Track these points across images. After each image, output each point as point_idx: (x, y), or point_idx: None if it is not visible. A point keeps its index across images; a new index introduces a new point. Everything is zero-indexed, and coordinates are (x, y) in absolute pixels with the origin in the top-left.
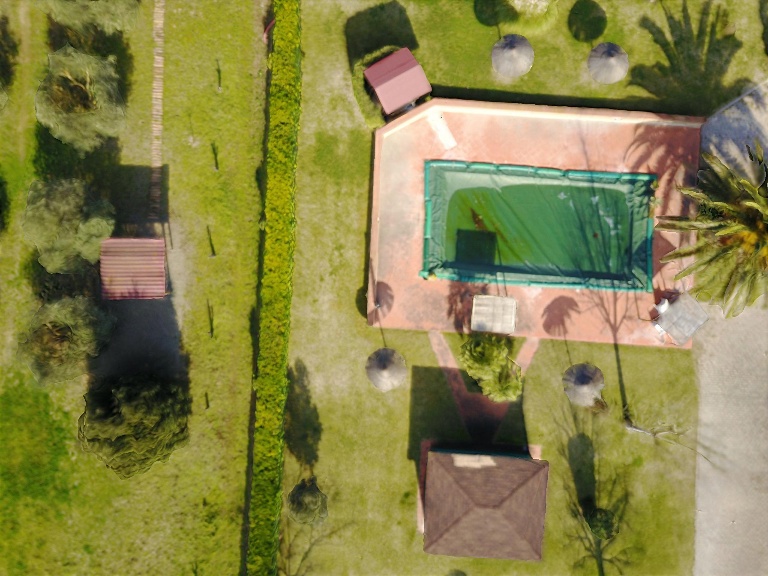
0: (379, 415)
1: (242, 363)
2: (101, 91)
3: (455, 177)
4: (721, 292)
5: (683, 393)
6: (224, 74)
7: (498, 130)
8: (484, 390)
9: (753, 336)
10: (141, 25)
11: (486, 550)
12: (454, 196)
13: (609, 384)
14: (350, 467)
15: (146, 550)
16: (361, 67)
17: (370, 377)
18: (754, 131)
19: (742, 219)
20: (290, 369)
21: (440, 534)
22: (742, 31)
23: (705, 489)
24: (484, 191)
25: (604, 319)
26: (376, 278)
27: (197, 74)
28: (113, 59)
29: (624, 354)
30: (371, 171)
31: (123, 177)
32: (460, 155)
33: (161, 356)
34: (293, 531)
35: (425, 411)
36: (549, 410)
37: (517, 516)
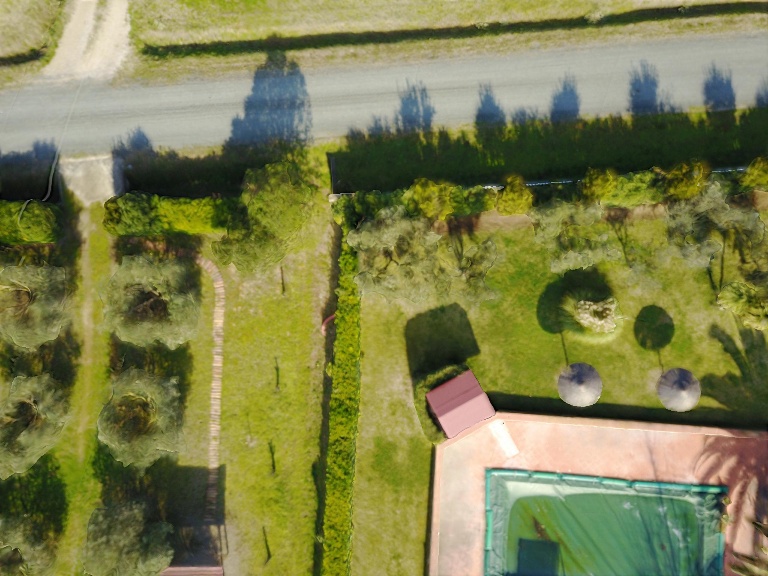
0: None
1: None
2: (163, 416)
3: (517, 486)
4: None
5: None
6: (282, 371)
7: (561, 438)
8: None
9: None
10: (201, 324)
11: None
12: (516, 504)
13: None
14: None
15: None
16: (423, 389)
17: None
18: None
19: None
20: None
21: None
22: None
23: None
24: (547, 499)
25: None
26: None
27: (255, 372)
28: (175, 380)
29: None
30: (431, 480)
31: (180, 477)
32: (522, 463)
33: None
34: None
35: None
36: None
37: None
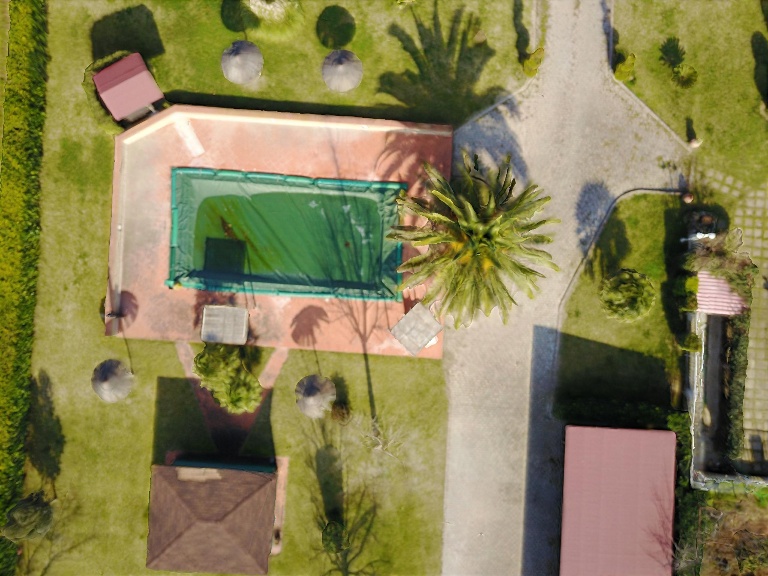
0: (123, 427)
1: None
2: None
3: (202, 185)
4: (451, 303)
5: (433, 404)
6: None
7: (247, 137)
8: (221, 402)
9: (504, 346)
10: None
11: (210, 565)
12: (203, 204)
13: (358, 395)
14: (92, 480)
15: None
16: (91, 72)
17: (95, 389)
18: (508, 140)
19: (453, 230)
20: (34, 380)
21: (162, 549)
22: (495, 39)
23: (454, 501)
24: (234, 199)
25: (354, 329)
26: (120, 287)
27: None
28: None
29: (374, 365)
30: None
31: None
32: (208, 162)
33: None
34: (32, 546)
35: (170, 423)
36: (297, 421)
37: (241, 531)
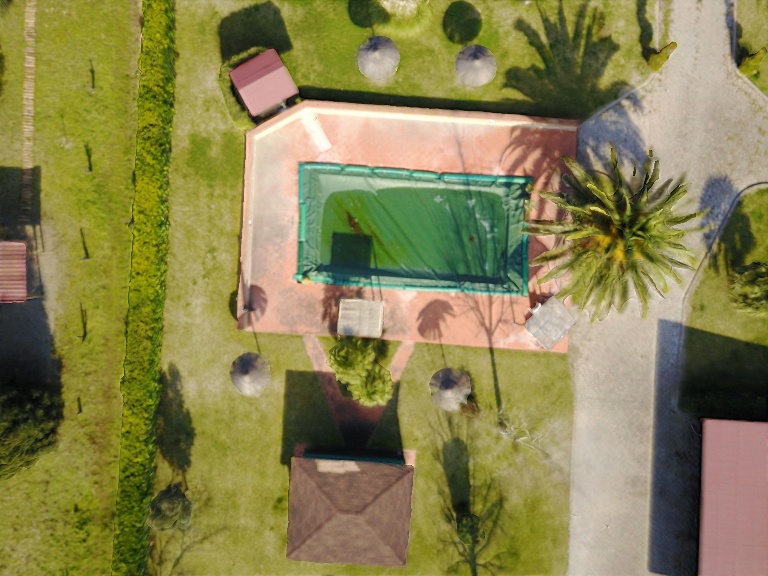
0: (252, 420)
1: (118, 367)
2: None
3: (330, 180)
4: None
5: (558, 397)
6: (98, 75)
7: (373, 132)
8: (354, 395)
9: (629, 340)
10: (12, 24)
11: (349, 556)
12: (329, 199)
13: (484, 388)
14: (223, 472)
15: (15, 557)
16: (227, 68)
17: (234, 382)
18: (631, 134)
19: (598, 223)
20: (163, 373)
21: (303, 540)
22: (619, 34)
23: (580, 493)
24: (360, 194)
25: (479, 323)
26: (249, 281)
27: (70, 74)
28: None
29: (500, 358)
30: (244, 173)
31: None
32: (335, 157)
33: (32, 360)
34: (165, 537)
35: (299, 416)
36: (424, 414)
37: (380, 522)
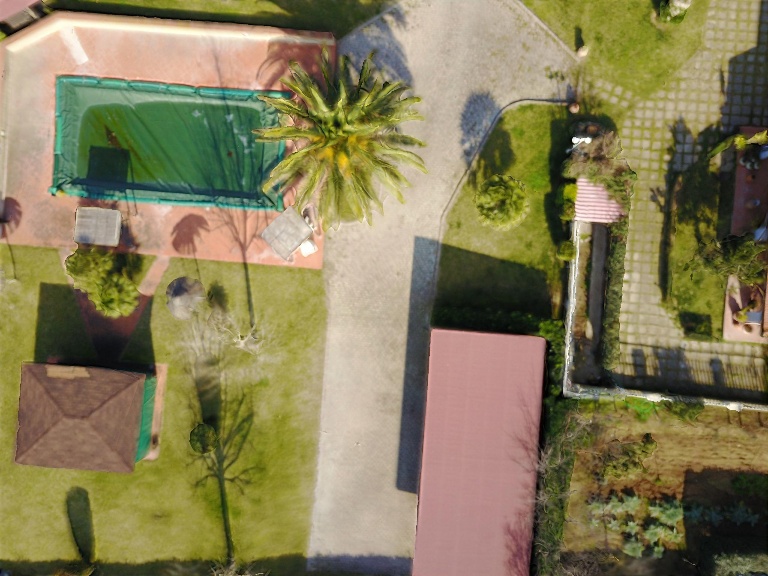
0: (6, 331)
1: None
2: None
3: (86, 93)
4: (320, 205)
5: (313, 314)
6: None
7: (130, 46)
8: (96, 305)
9: (385, 257)
10: None
11: (77, 461)
12: (87, 112)
13: (237, 303)
14: None
15: None
16: None
17: None
18: (393, 50)
19: (312, 125)
20: None
21: (31, 444)
22: None
23: (331, 410)
24: (118, 108)
25: (234, 238)
26: (4, 194)
27: None
28: None
29: (254, 274)
30: None
31: None
32: (91, 70)
33: None
34: None
35: (52, 328)
36: (177, 329)
37: (108, 428)
